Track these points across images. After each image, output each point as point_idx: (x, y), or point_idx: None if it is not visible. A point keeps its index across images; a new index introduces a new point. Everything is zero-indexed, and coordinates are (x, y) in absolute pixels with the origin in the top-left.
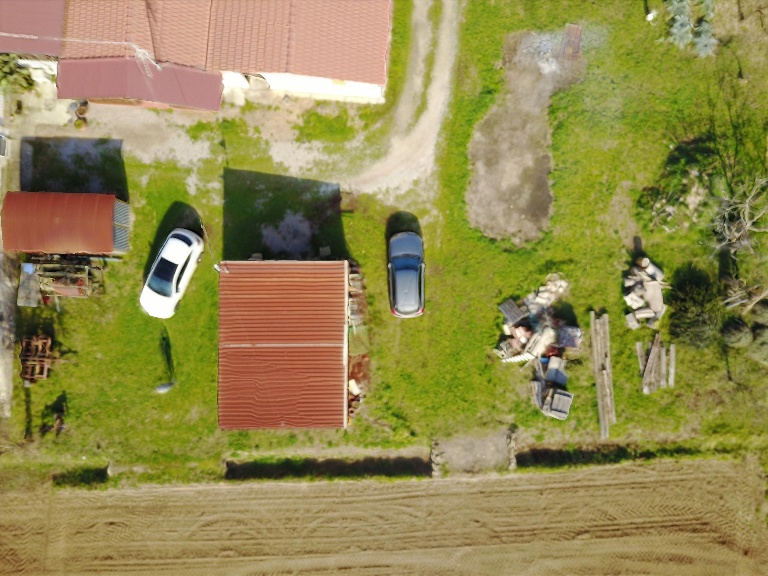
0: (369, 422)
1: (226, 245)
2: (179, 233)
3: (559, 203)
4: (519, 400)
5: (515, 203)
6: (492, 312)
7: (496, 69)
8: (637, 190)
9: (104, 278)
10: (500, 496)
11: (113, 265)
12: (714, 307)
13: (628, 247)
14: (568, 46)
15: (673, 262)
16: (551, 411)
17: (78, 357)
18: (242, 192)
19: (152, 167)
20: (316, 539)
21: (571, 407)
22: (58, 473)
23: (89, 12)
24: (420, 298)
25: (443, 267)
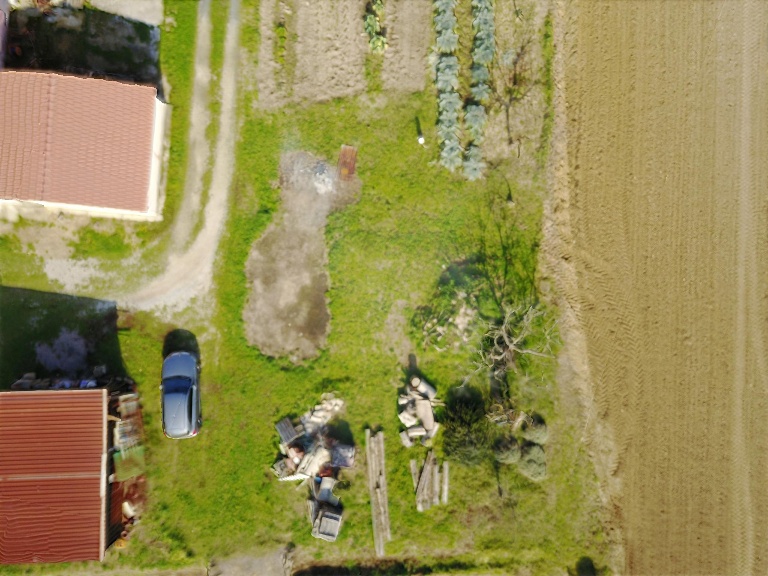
0: (144, 544)
1: None
2: None
3: (336, 321)
4: (296, 519)
5: (293, 321)
6: (269, 430)
7: (274, 188)
8: (411, 308)
9: None
10: None
11: None
12: (481, 426)
13: (403, 365)
14: (344, 167)
15: (447, 379)
16: (319, 534)
17: None
18: (16, 310)
19: None
20: None
21: (347, 525)
22: None
23: None
24: (190, 421)
25: (221, 385)
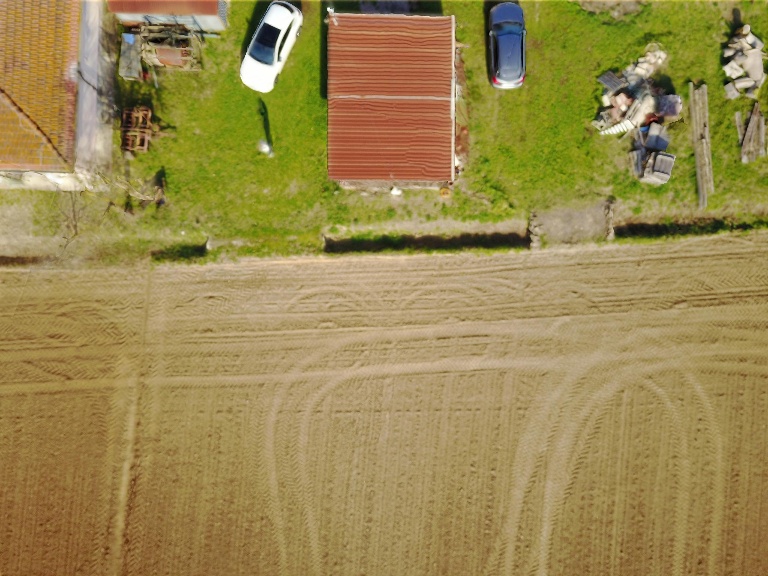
0: (467, 195)
1: None
2: (280, 2)
3: None
4: (617, 172)
5: None
6: (590, 85)
7: None
8: None
9: (202, 55)
10: (597, 268)
11: (211, 42)
12: None
13: (727, 19)
14: None
15: None
16: (653, 173)
17: (177, 132)
18: None
19: None
20: (414, 311)
21: (669, 178)
22: (156, 250)
23: None
24: (522, 64)
25: (541, 41)
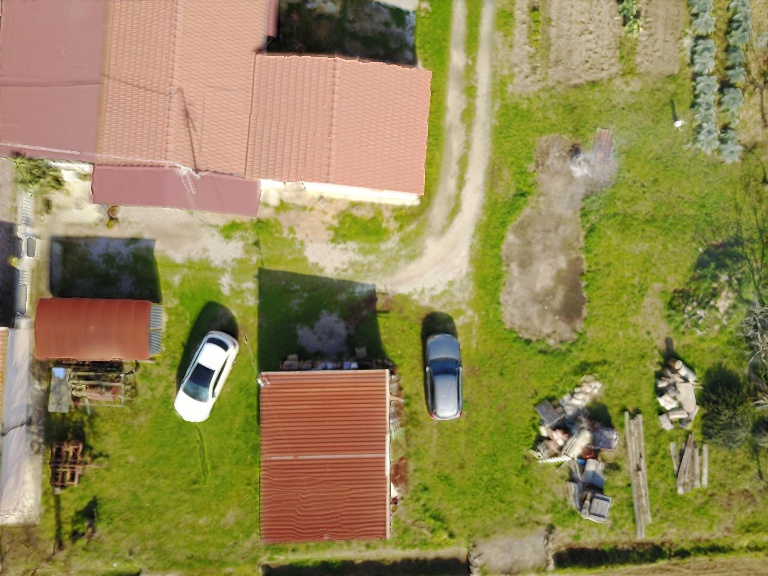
0: (406, 524)
1: (261, 346)
2: (215, 337)
3: (592, 304)
4: (555, 500)
5: (549, 304)
6: (528, 412)
7: (529, 172)
8: (668, 291)
9: (136, 380)
10: None
11: (145, 367)
12: (745, 409)
13: (660, 347)
14: (599, 150)
15: (704, 362)
16: (590, 515)
17: (109, 462)
18: (277, 293)
19: (186, 267)
20: None
21: None
22: None
23: (127, 120)
24: (458, 402)
25: (479, 368)
